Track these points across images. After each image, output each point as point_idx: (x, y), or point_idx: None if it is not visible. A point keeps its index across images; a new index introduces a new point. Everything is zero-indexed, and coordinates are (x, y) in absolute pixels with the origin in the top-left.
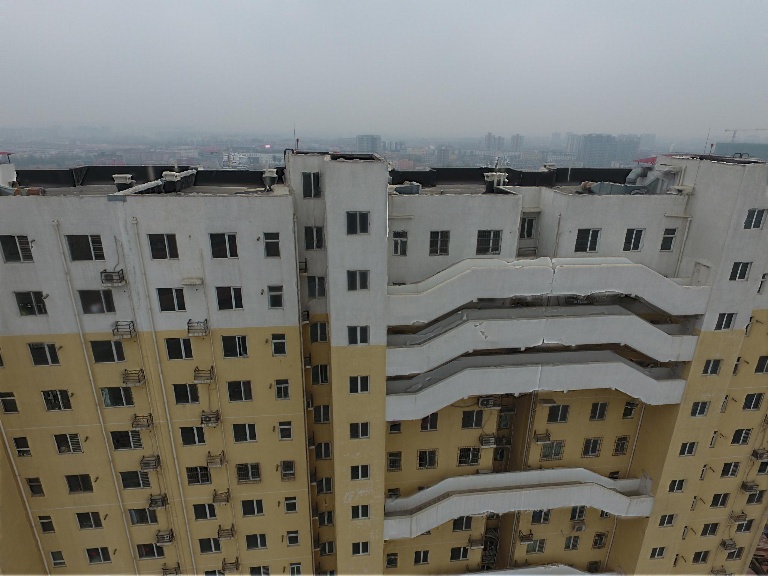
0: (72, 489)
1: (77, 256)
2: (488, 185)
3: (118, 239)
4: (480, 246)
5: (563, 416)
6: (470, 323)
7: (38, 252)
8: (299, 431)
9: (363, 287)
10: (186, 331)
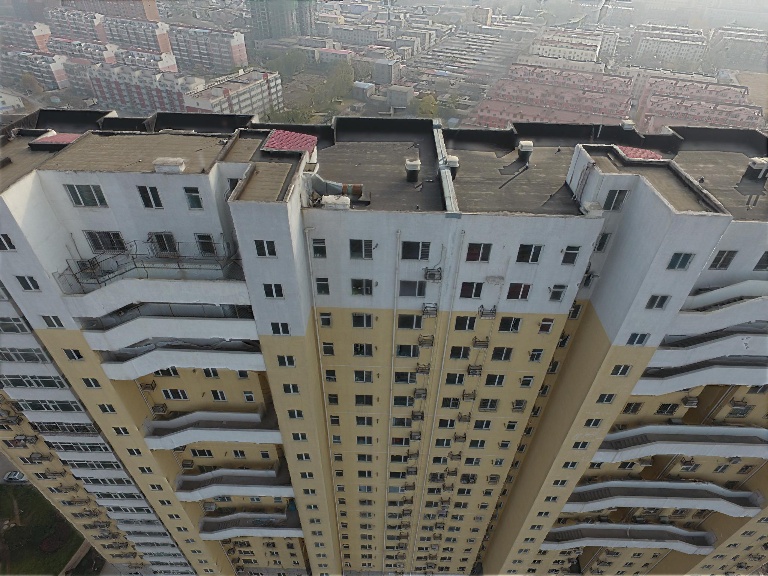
0: (357, 402)
1: (405, 255)
2: (751, 172)
3: (445, 246)
4: (760, 264)
5: (763, 389)
6: (739, 337)
7: (379, 253)
8: (538, 383)
9: (659, 307)
10: (476, 313)
